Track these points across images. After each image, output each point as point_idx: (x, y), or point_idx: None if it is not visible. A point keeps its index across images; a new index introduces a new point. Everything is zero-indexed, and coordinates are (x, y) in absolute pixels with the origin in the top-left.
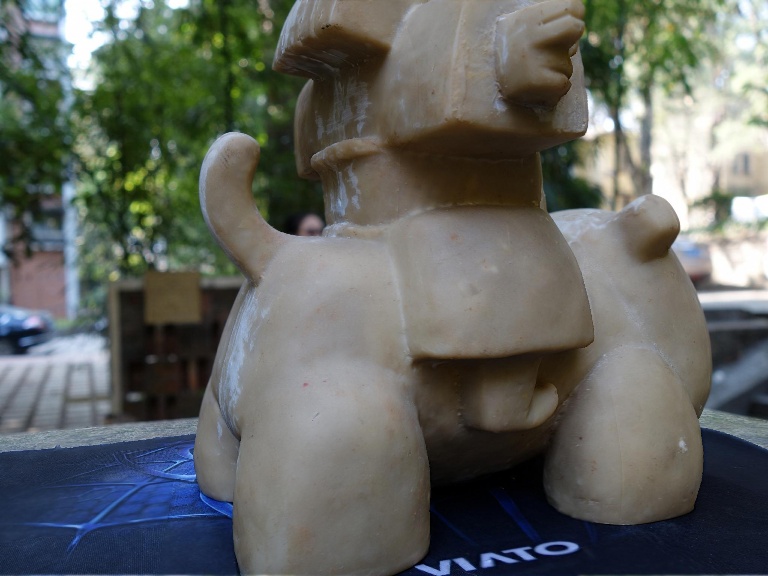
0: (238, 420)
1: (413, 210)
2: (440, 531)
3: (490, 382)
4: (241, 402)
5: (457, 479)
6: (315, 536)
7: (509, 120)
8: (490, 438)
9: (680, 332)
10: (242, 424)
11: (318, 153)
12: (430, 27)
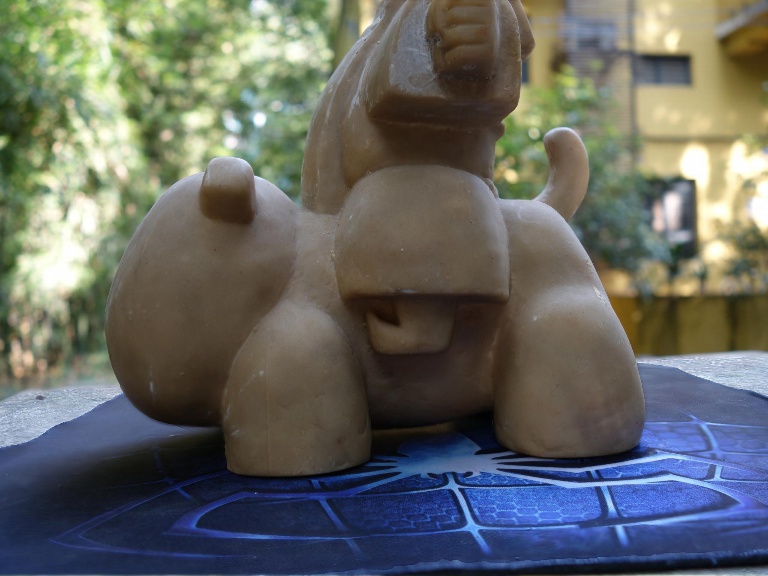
0: None
1: None
2: None
3: None
4: None
5: None
6: None
7: None
8: None
9: None
10: None
11: None
12: None
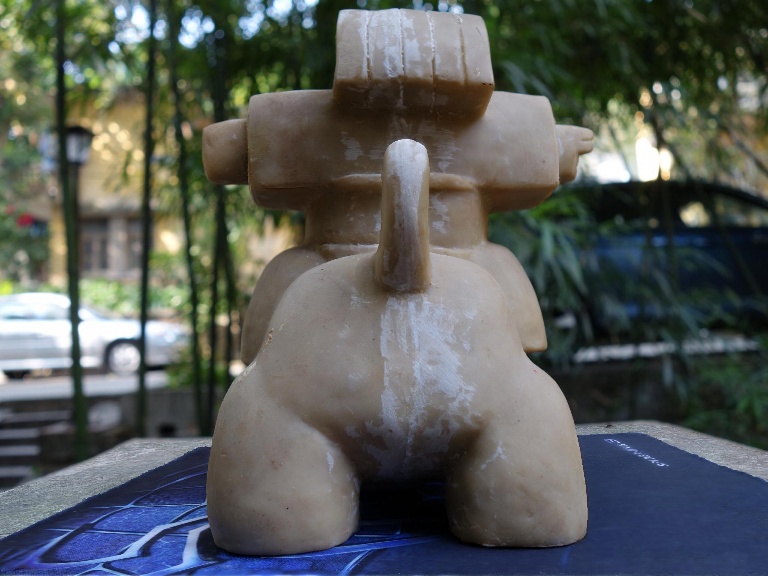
0: (482, 415)
1: (482, 241)
2: None
3: None
4: (482, 397)
5: None
6: None
7: None
8: None
9: None
10: (490, 417)
11: None
12: (524, 114)
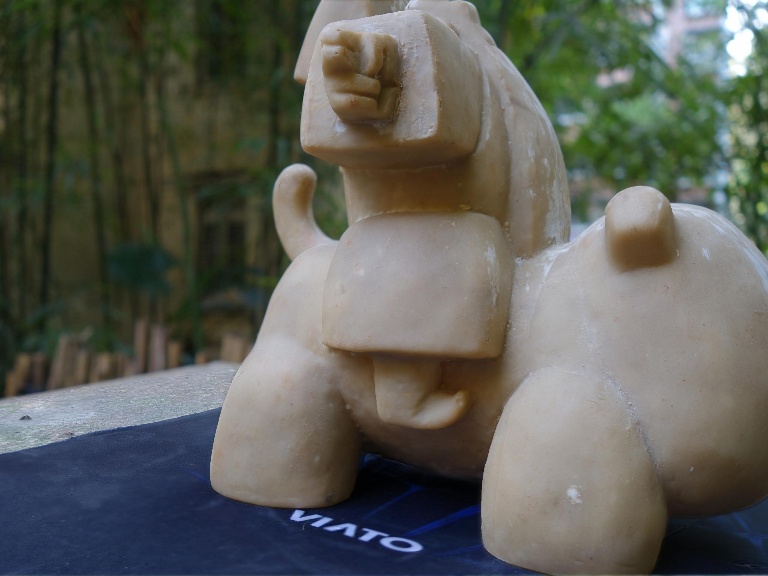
0: None
1: (358, 219)
2: (372, 503)
3: (378, 376)
4: None
5: (441, 472)
6: (223, 456)
7: (349, 139)
8: (422, 434)
9: (658, 364)
10: None
11: None
12: None
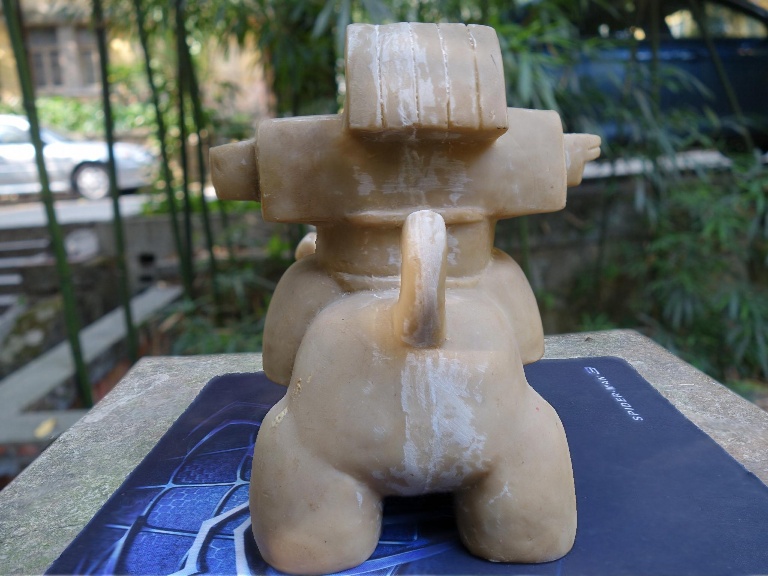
0: (491, 460)
1: (489, 262)
2: None
3: None
4: (492, 445)
5: None
6: None
7: None
8: None
9: None
10: (498, 461)
11: (397, 214)
12: (535, 136)
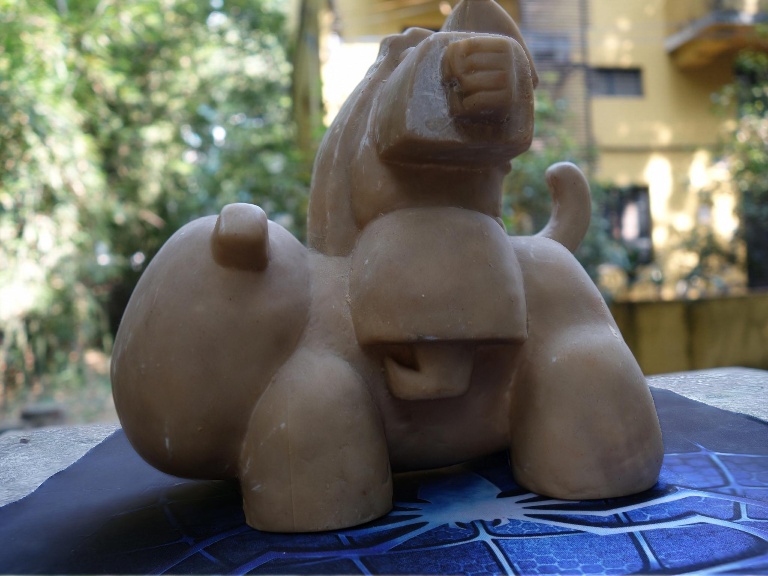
0: None
1: None
2: None
3: None
4: None
5: None
6: None
7: None
8: None
9: None
10: None
11: None
12: None
